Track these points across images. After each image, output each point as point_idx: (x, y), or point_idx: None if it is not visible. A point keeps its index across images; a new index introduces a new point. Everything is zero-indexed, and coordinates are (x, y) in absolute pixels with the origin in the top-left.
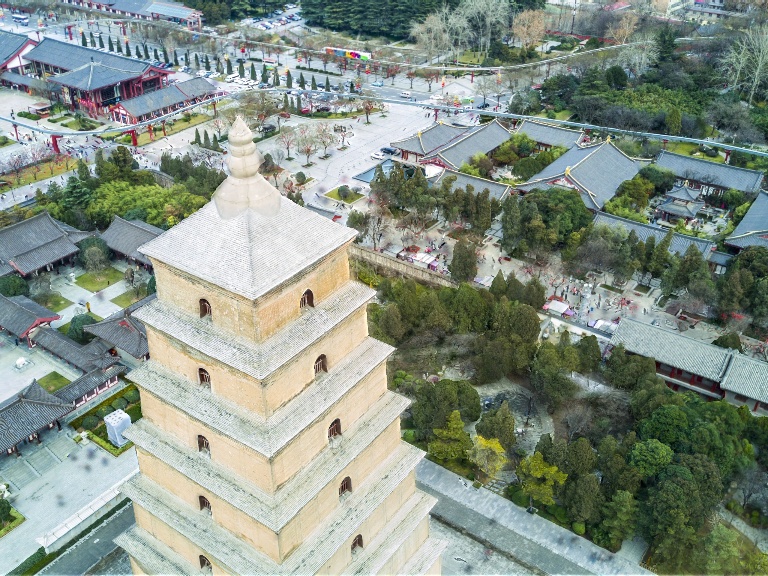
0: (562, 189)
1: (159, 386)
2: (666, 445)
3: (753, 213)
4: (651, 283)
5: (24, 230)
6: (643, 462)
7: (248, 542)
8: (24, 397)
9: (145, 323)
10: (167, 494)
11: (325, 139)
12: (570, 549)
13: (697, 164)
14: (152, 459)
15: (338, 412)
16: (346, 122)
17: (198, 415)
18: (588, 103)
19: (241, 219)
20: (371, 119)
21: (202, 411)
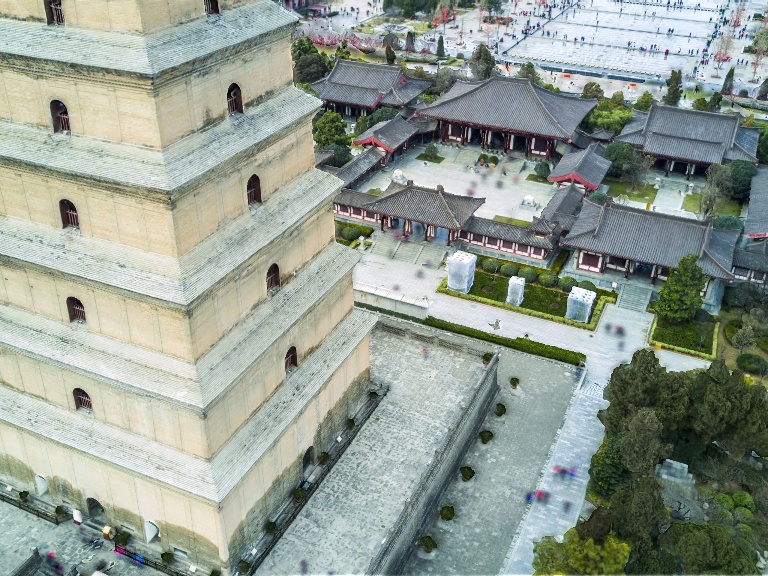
0: None
1: None
2: None
3: None
4: None
5: (699, 121)
6: None
7: None
8: (444, 193)
9: None
10: None
11: None
12: None
13: None
14: None
15: (63, 93)
16: None
17: None
18: None
19: None
20: None
21: None
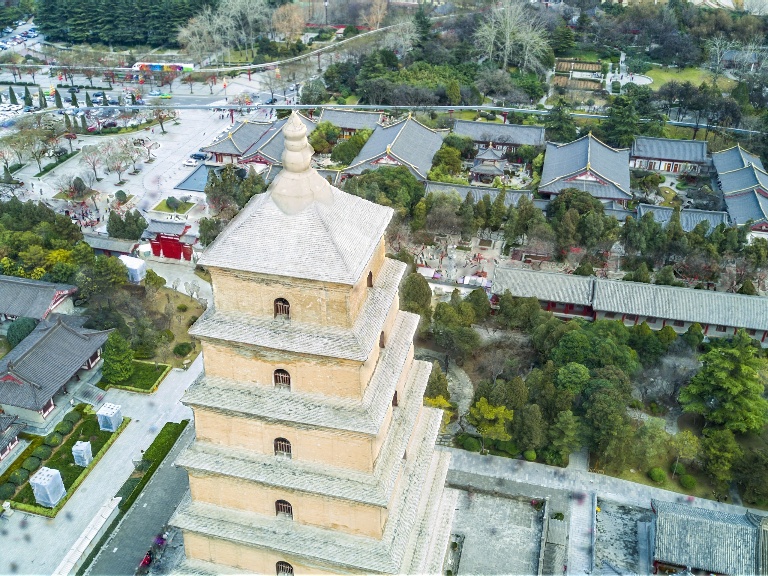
0: (390, 166)
1: (226, 400)
2: (582, 365)
3: (550, 162)
4: (490, 237)
5: None
6: (569, 384)
7: (340, 529)
8: None
9: (205, 338)
10: (231, 512)
11: (132, 154)
12: (530, 475)
13: (488, 127)
14: (212, 480)
15: None
16: (140, 135)
17: (284, 416)
18: (376, 85)
19: (310, 211)
20: (165, 128)
21: (286, 411)
